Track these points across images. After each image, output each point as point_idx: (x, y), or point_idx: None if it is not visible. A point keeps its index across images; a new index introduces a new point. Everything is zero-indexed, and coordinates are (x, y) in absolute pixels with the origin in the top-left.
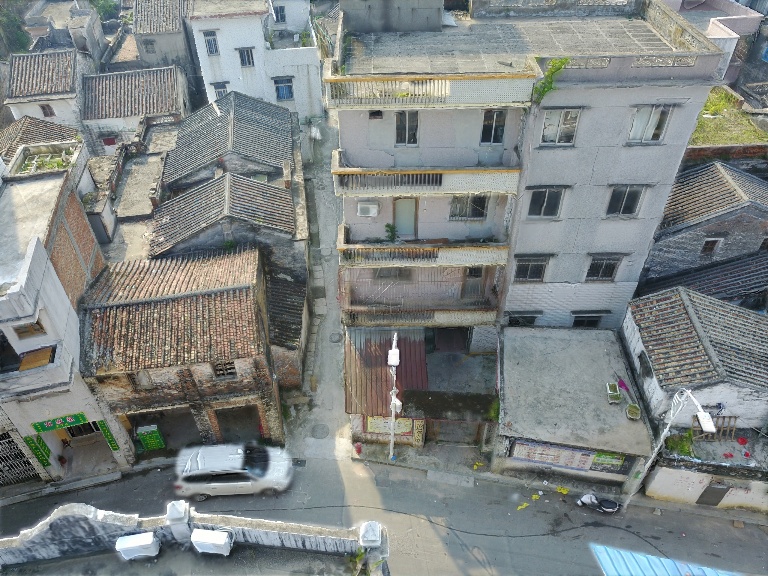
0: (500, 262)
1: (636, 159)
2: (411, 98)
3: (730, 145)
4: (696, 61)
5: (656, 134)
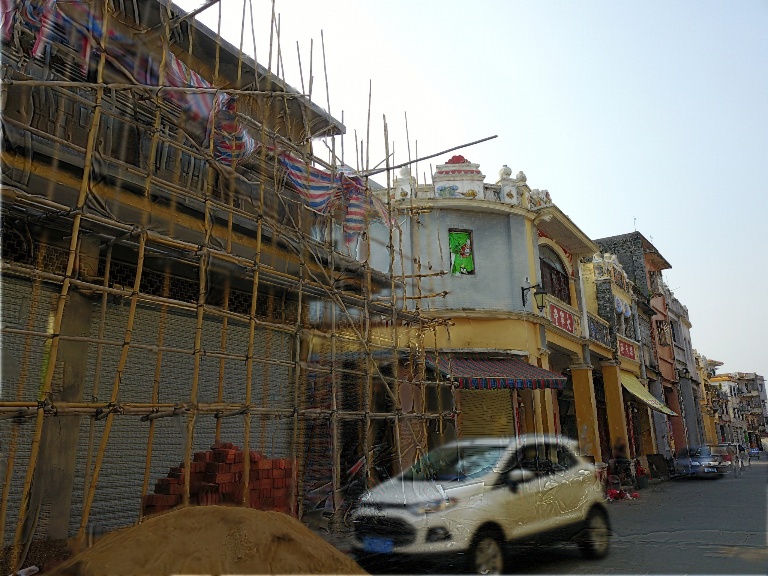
0: (761, 412)
1: (762, 395)
2: (745, 376)
3: None
4: (761, 377)
5: (762, 390)
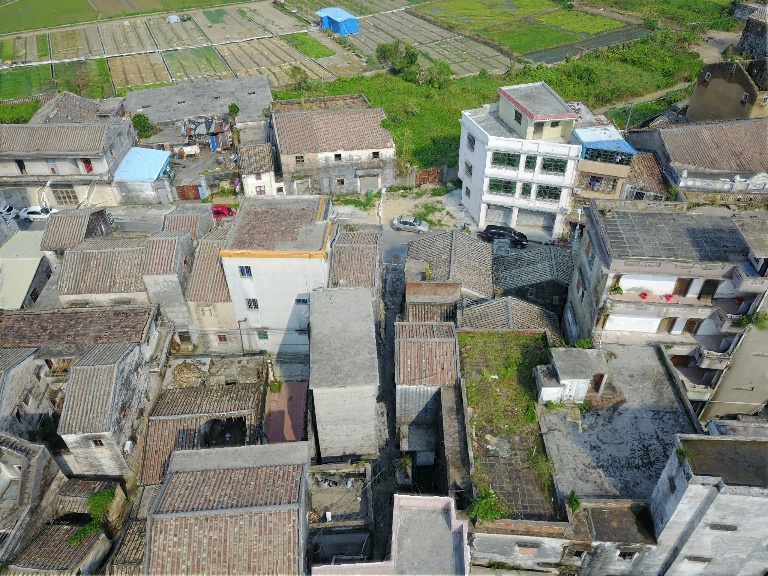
0: None
1: None
2: None
3: (503, 328)
4: (602, 203)
5: None
